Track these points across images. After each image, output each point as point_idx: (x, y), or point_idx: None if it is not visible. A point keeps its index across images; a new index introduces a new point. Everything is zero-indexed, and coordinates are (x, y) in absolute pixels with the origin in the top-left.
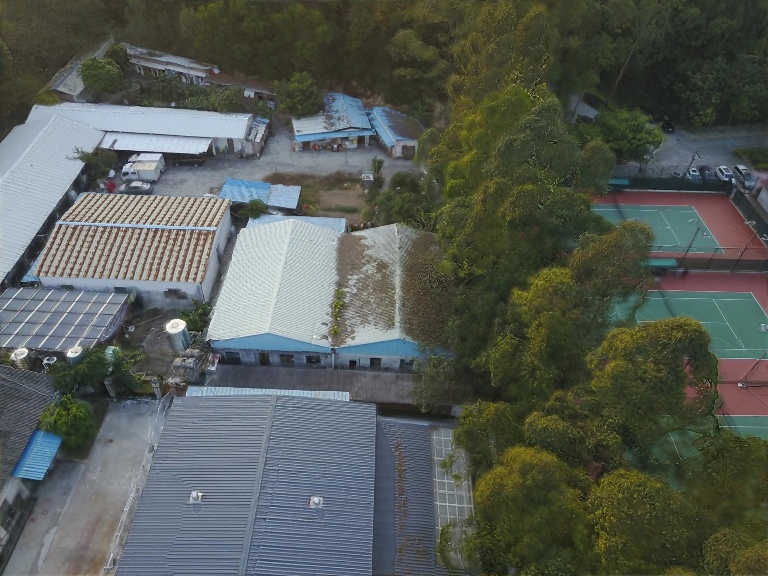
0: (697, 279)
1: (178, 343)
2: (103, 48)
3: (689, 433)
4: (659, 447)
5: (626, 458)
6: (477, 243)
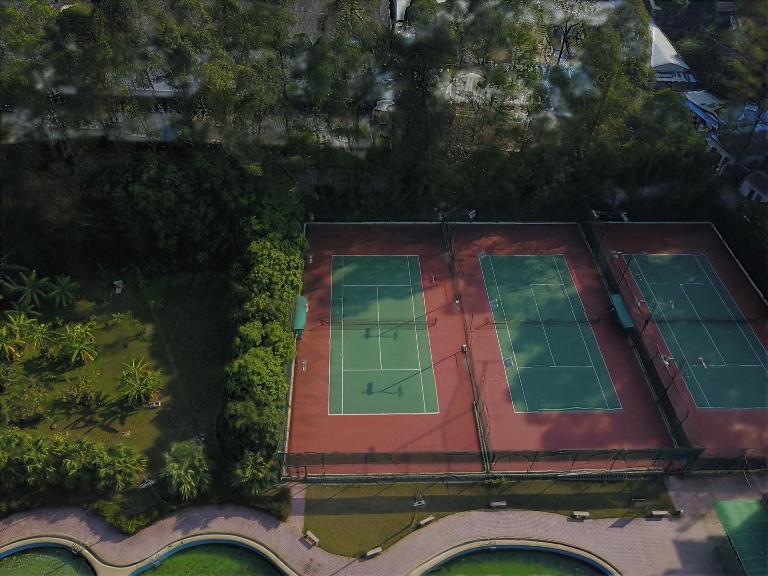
0: (626, 362)
1: None
2: (727, 3)
3: (405, 296)
4: (390, 276)
5: (262, 35)
6: None
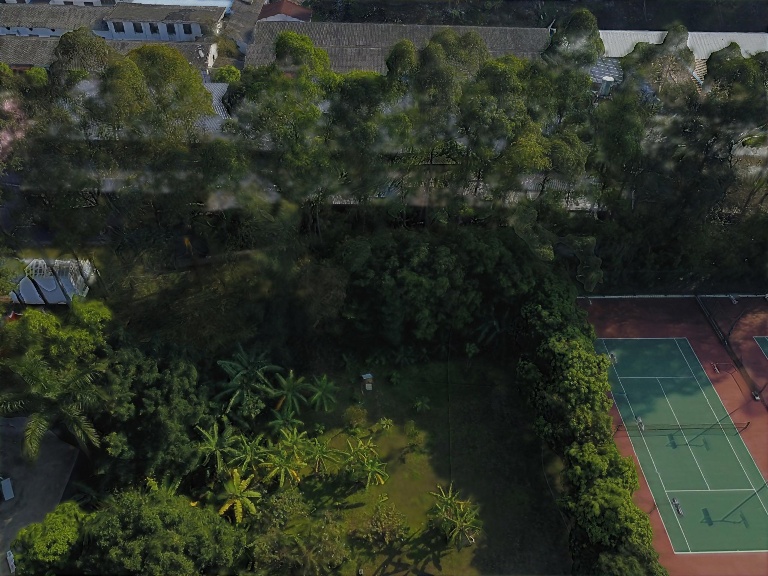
0: None
1: (601, 88)
2: None
3: (695, 391)
4: (666, 364)
5: None
6: (763, 154)
